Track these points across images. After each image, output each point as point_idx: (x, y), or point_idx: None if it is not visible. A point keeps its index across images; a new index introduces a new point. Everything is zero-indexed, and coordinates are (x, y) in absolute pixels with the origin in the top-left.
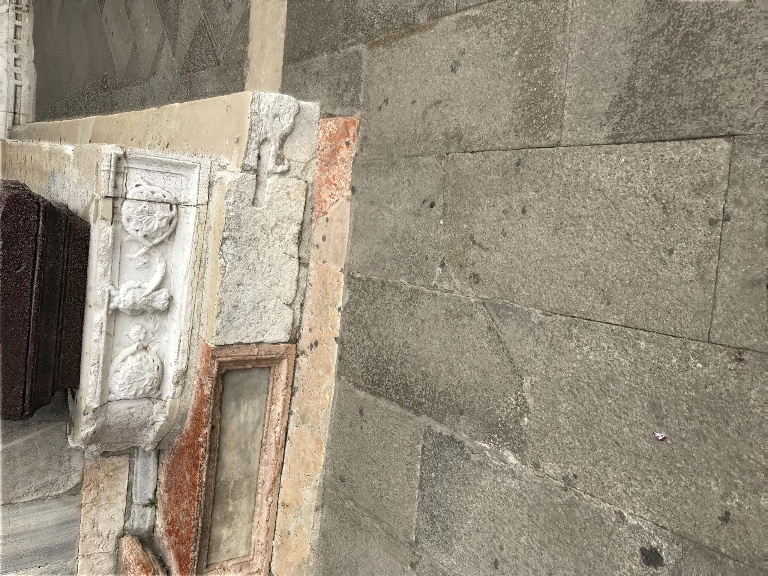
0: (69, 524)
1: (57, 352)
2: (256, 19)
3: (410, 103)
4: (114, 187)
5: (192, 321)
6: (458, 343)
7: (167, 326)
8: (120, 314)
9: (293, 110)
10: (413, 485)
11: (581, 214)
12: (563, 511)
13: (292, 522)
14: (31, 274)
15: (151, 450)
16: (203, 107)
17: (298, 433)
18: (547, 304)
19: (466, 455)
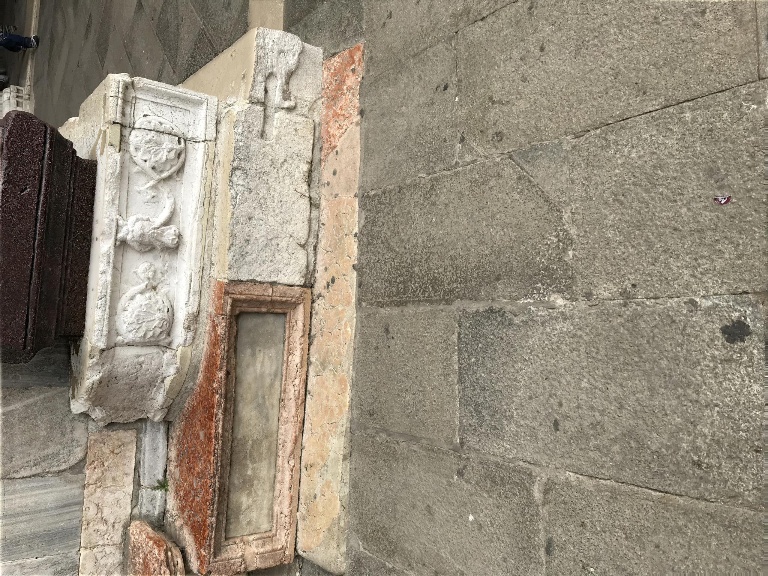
0: (70, 508)
1: (62, 291)
2: (254, 2)
3: (414, 4)
4: (122, 114)
5: (203, 261)
6: (487, 209)
7: (177, 267)
8: (128, 249)
9: (297, 47)
10: (452, 382)
11: (603, 22)
12: (625, 329)
13: (318, 482)
14: (37, 197)
15: (160, 420)
16: (207, 68)
17: (319, 382)
18: (578, 125)
19: (508, 321)
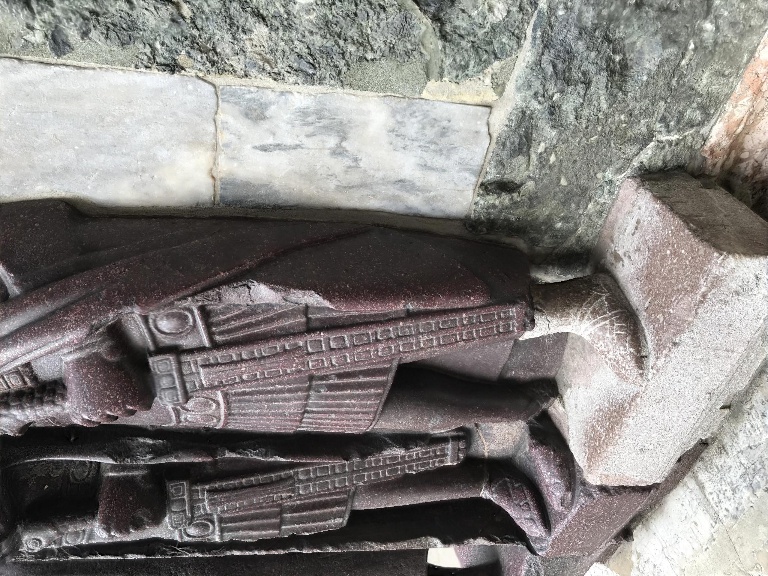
0: None
1: None
2: None
3: None
4: None
5: None
6: None
7: None
8: None
9: None
10: None
11: None
12: None
13: None
14: None
15: None
16: None
17: None
18: None
19: None
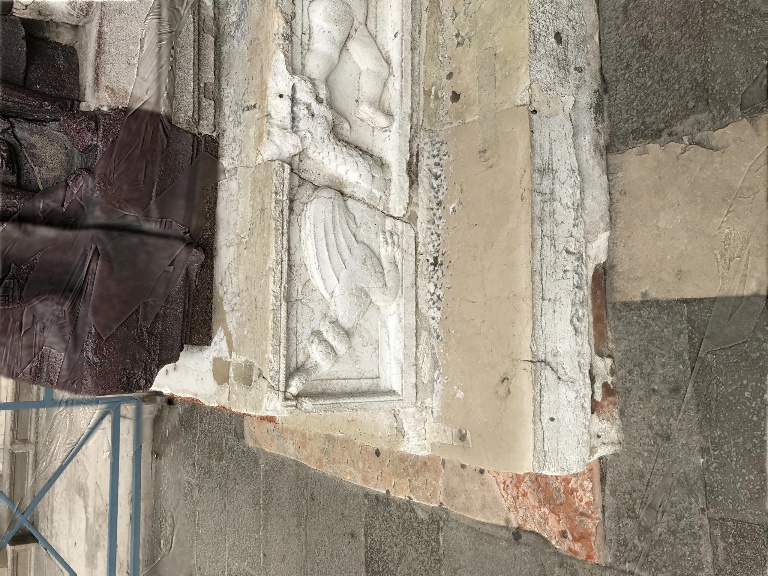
0: None
1: None
2: None
3: None
4: None
5: None
6: None
7: None
8: None
9: None
10: None
11: None
12: None
13: None
14: None
15: None
16: (511, 258)
17: None
18: None
19: None
